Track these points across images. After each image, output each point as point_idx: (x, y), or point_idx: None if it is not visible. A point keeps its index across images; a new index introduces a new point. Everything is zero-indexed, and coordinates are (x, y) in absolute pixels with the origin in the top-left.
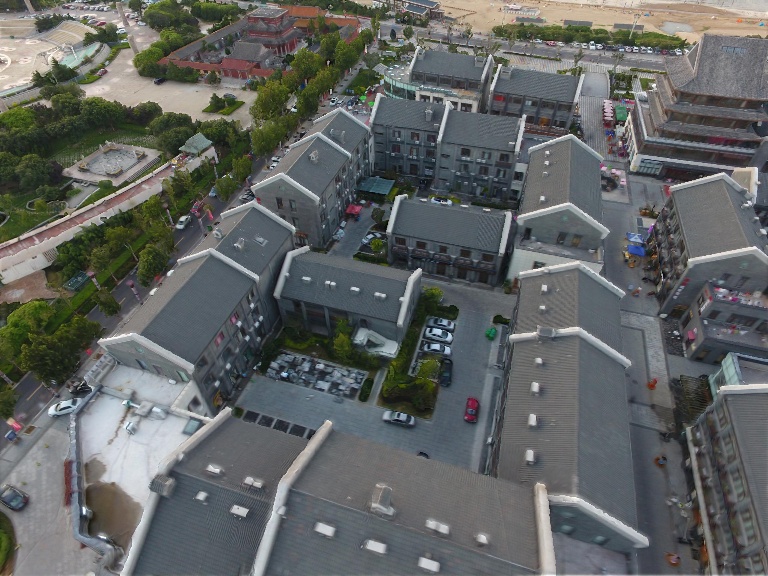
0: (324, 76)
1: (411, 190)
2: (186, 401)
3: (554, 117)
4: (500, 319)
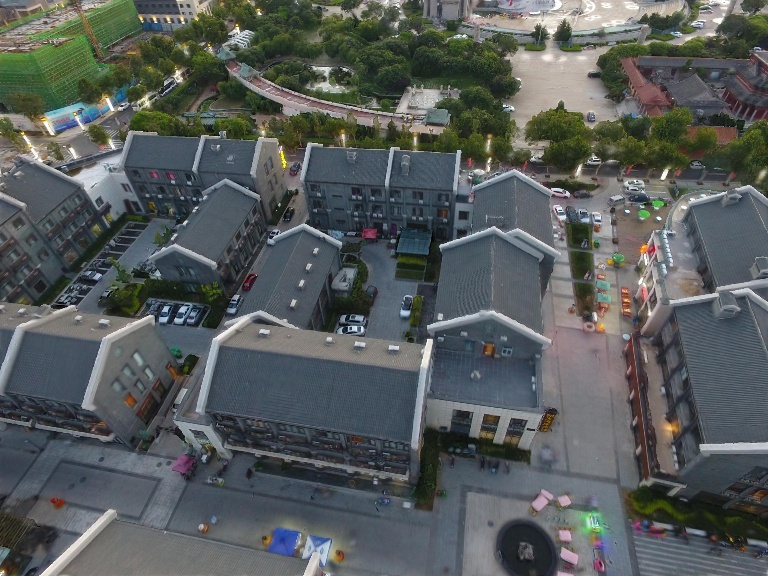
0: (629, 145)
1: (426, 276)
2: (120, 180)
3: (683, 435)
4: (188, 358)
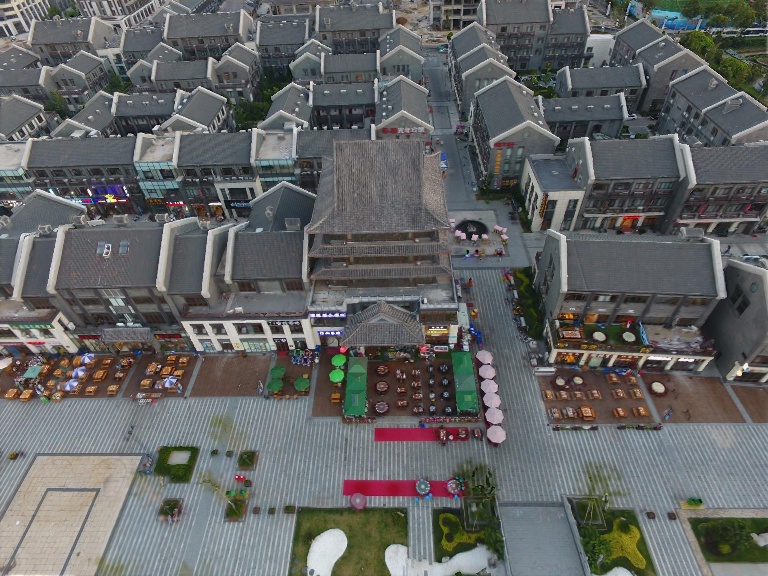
0: None
1: None
2: None
3: None
4: None
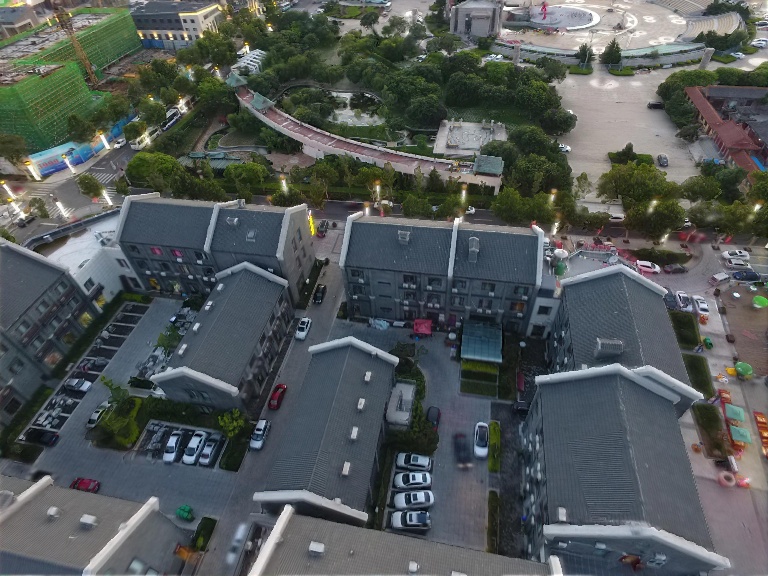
0: (736, 212)
1: (500, 391)
2: (114, 255)
3: None
4: (203, 525)
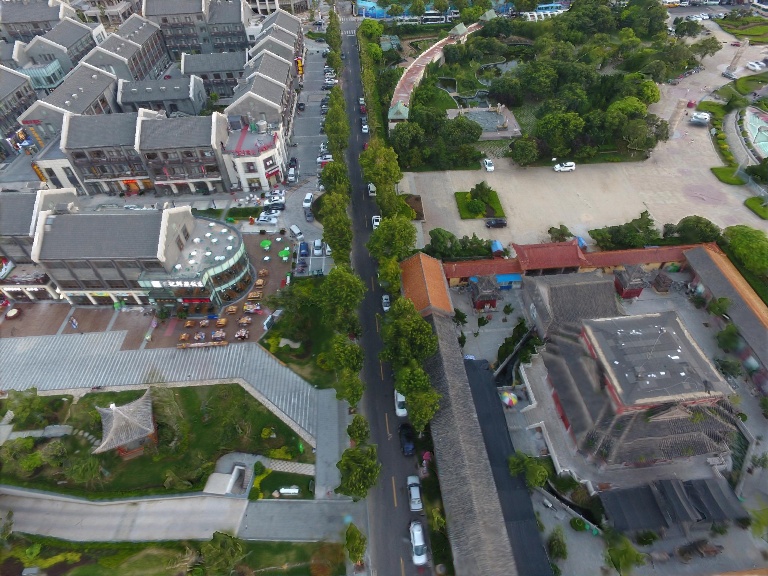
0: None
1: None
2: None
3: None
4: None
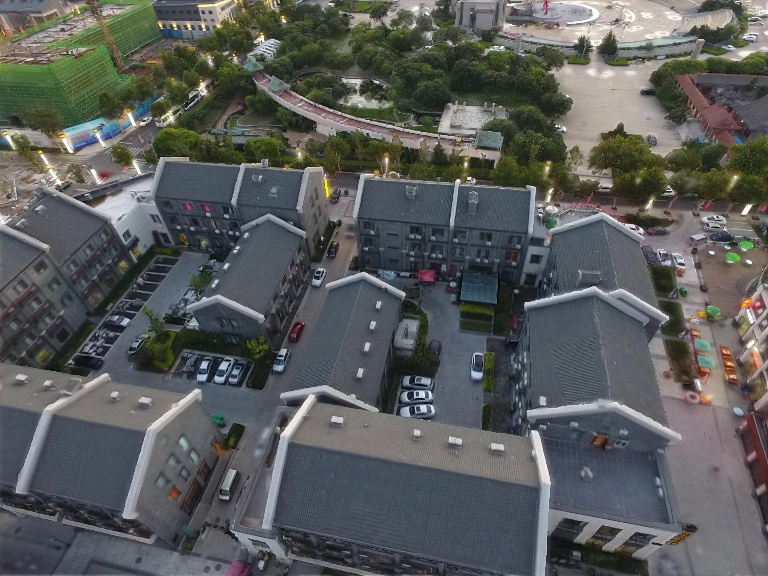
0: (713, 178)
1: (495, 329)
2: (149, 210)
3: None
4: (234, 429)
